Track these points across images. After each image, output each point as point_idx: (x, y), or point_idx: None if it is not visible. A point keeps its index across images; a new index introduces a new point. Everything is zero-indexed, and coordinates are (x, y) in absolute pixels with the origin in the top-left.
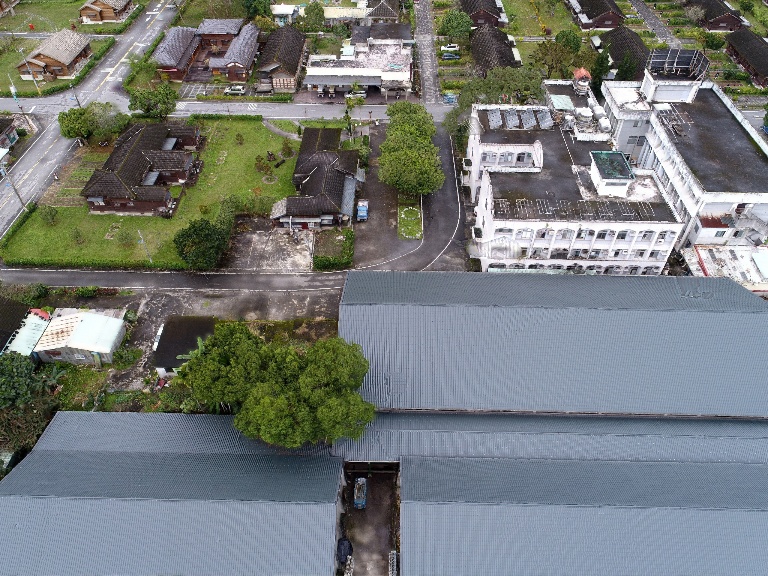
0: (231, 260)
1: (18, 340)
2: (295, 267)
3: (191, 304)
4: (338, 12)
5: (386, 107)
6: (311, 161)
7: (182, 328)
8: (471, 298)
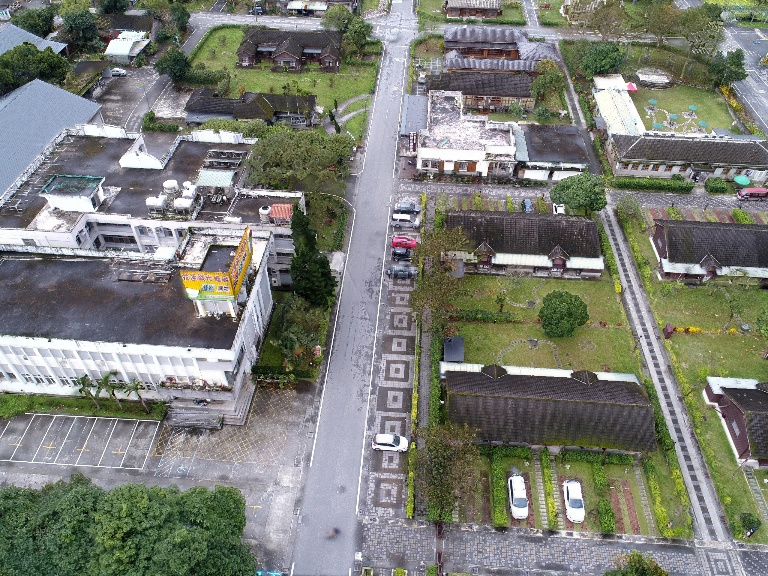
0: (178, 90)
1: (128, 33)
2: (157, 111)
3: (142, 80)
4: (612, 114)
5: (391, 156)
6: (251, 94)
7: (99, 65)
8: (6, 125)
